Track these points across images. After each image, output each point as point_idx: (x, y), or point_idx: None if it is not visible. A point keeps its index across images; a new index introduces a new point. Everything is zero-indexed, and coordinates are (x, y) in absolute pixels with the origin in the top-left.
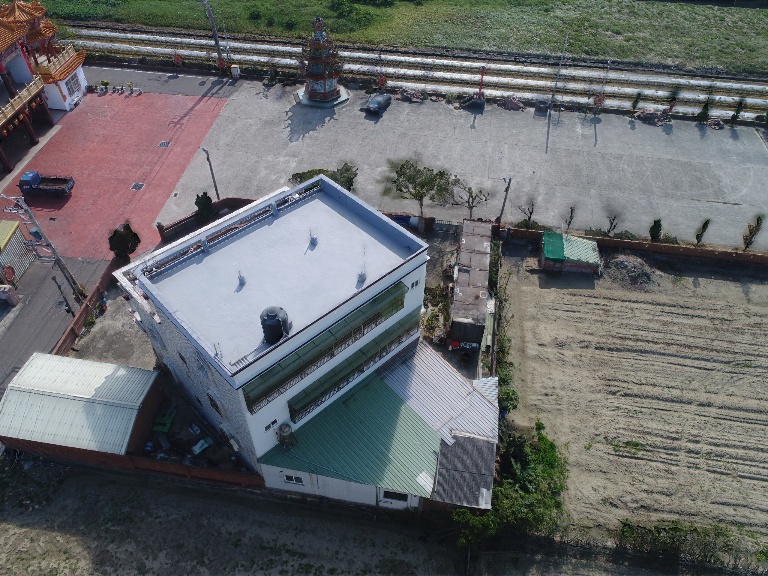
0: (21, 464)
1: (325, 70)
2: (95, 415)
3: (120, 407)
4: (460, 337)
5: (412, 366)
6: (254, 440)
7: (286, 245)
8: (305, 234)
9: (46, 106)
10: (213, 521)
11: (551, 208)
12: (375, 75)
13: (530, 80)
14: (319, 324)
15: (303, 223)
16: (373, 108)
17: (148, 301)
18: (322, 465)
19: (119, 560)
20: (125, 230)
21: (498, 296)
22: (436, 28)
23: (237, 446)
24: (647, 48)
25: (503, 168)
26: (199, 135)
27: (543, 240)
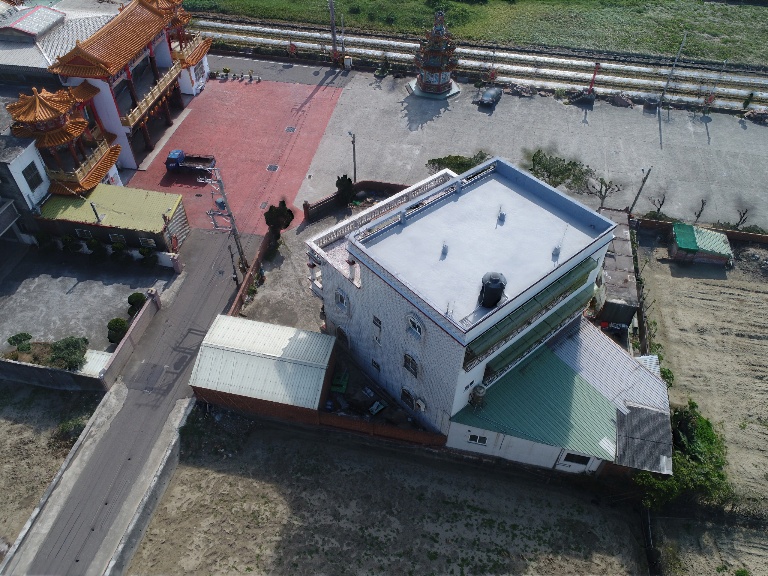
0: (212, 416)
1: (441, 63)
2: (286, 373)
3: (309, 366)
4: (610, 318)
5: (578, 341)
6: (455, 398)
7: (476, 220)
8: (491, 210)
9: (180, 90)
10: (395, 476)
11: (675, 201)
12: (479, 70)
13: (633, 79)
14: (530, 291)
15: (486, 200)
16: (487, 101)
17: (351, 267)
18: (510, 426)
19: (314, 506)
20: (282, 206)
21: (641, 281)
22: (532, 26)
23: (424, 406)
24: (746, 50)
25: (621, 162)
26: (322, 122)
27: (674, 231)
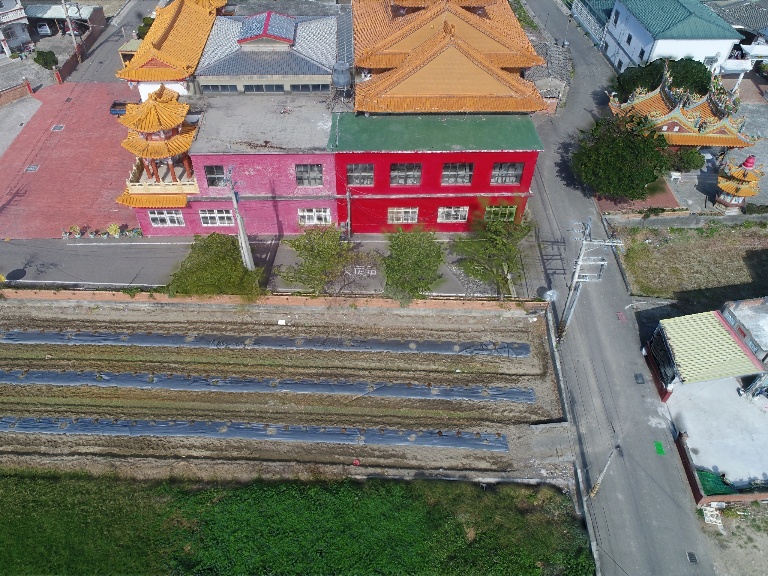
0: None
1: None
2: None
3: None
4: None
5: None
6: None
7: None
8: None
9: None
10: None
11: None
12: None
13: None
14: None
15: None
16: None
17: None
18: None
19: None
20: None
21: None
22: None
23: None
24: None
25: None
26: None
27: None
